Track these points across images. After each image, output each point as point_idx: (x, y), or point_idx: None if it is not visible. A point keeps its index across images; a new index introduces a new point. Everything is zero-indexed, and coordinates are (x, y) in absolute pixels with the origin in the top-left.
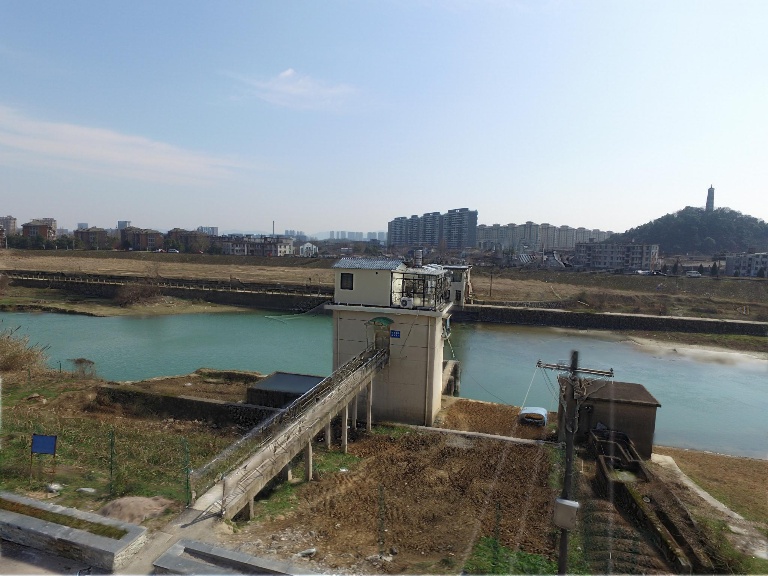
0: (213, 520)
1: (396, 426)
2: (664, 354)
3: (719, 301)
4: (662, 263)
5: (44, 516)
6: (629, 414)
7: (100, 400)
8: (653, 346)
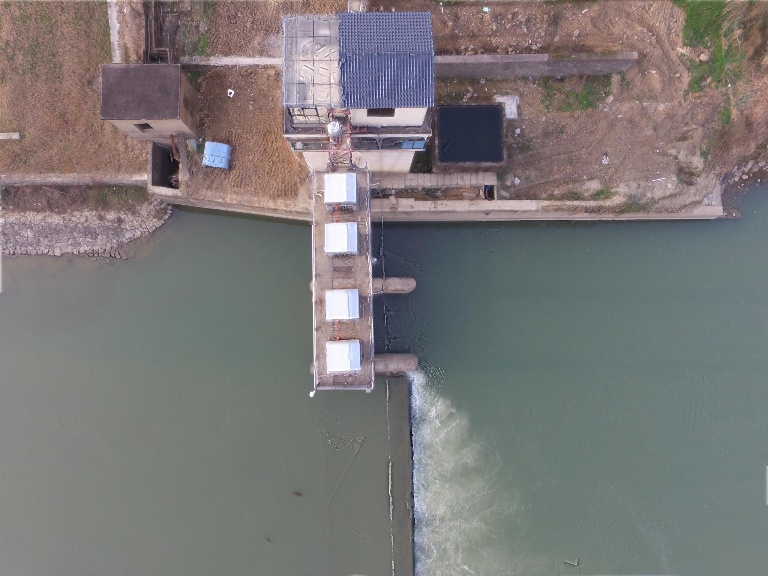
0: None
1: None
2: None
3: None
4: None
5: None
6: None
7: None
8: None
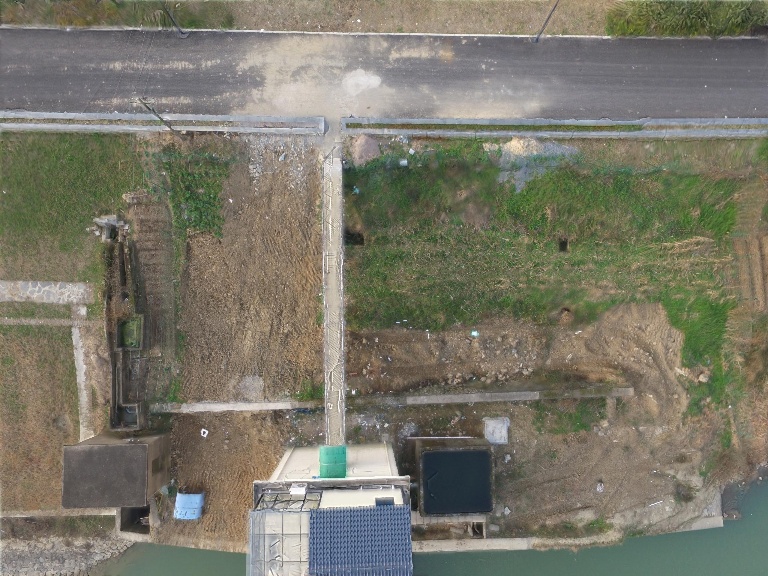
0: (326, 155)
1: (310, 399)
2: None
3: None
4: None
5: (387, 125)
6: None
7: (616, 376)
8: None
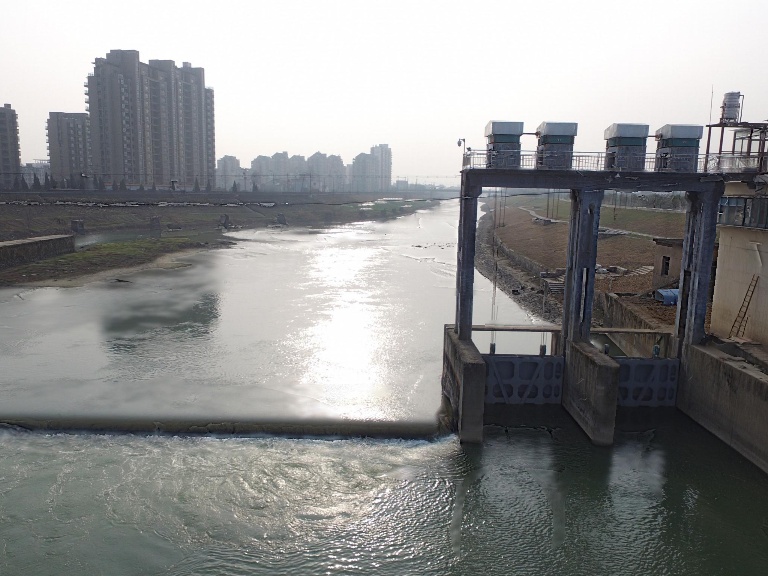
0: None
1: None
2: None
3: None
4: None
5: None
6: None
7: None
8: None
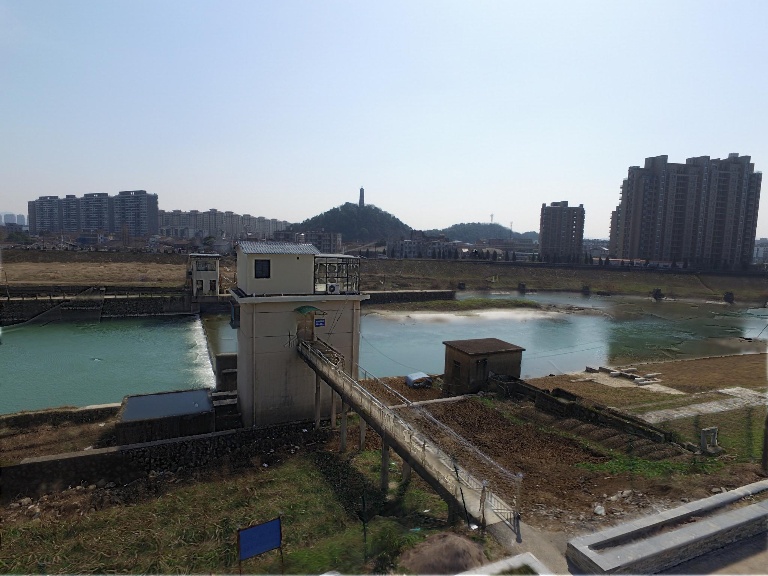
0: (524, 523)
1: (353, 415)
2: (404, 320)
3: (406, 277)
4: (365, 248)
5: None
6: (507, 360)
7: None
8: (393, 315)
